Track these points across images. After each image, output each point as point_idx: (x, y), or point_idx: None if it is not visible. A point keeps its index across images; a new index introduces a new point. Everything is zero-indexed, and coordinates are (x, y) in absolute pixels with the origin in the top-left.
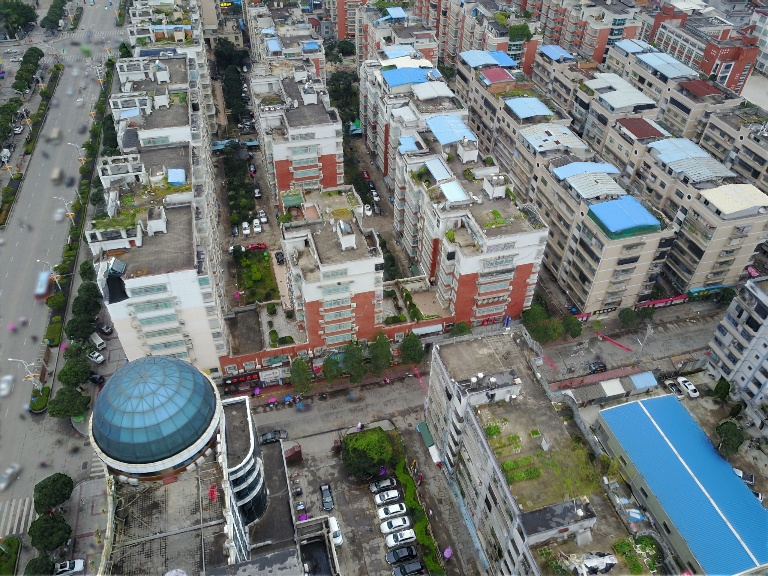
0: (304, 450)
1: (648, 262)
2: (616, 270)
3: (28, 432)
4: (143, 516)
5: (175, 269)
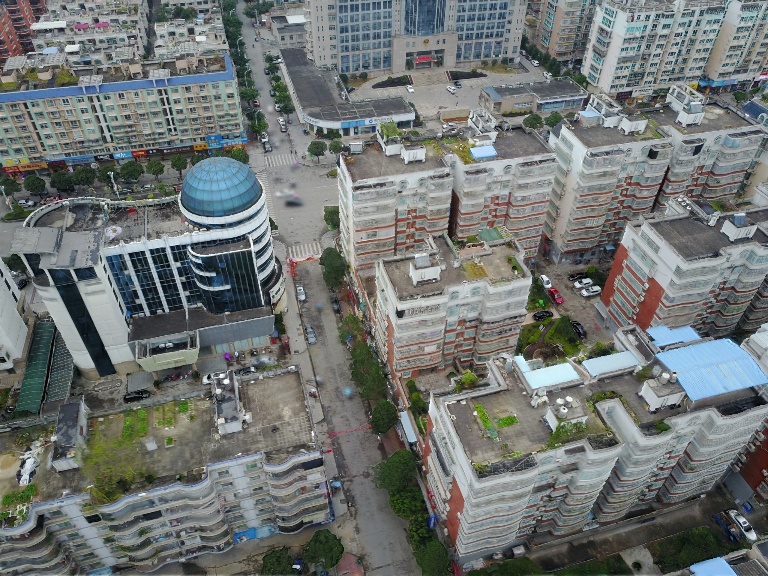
0: (295, 356)
1: None
2: None
3: None
4: (162, 214)
5: (358, 175)
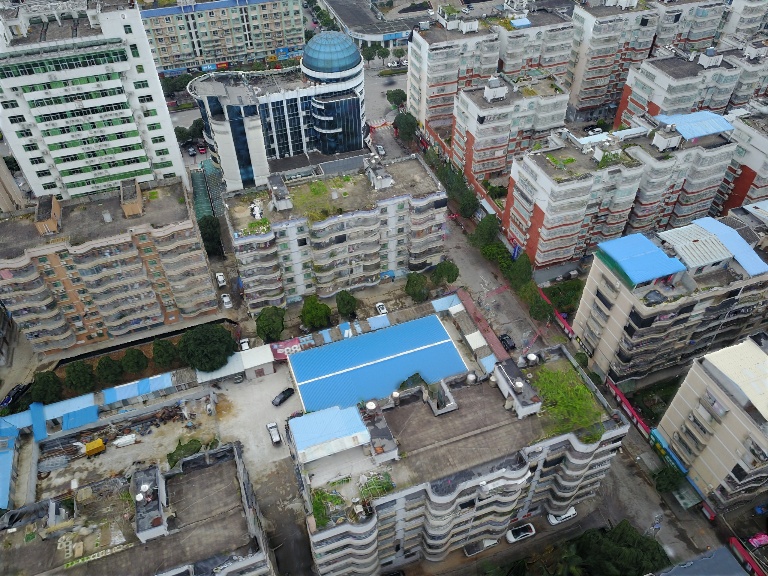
0: None
1: (622, 327)
2: (595, 300)
3: (385, 100)
4: (286, 79)
5: (431, 42)
